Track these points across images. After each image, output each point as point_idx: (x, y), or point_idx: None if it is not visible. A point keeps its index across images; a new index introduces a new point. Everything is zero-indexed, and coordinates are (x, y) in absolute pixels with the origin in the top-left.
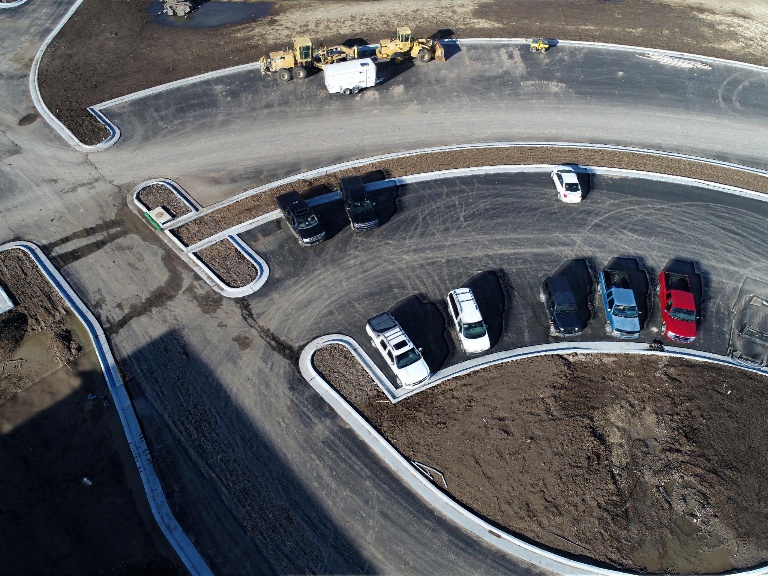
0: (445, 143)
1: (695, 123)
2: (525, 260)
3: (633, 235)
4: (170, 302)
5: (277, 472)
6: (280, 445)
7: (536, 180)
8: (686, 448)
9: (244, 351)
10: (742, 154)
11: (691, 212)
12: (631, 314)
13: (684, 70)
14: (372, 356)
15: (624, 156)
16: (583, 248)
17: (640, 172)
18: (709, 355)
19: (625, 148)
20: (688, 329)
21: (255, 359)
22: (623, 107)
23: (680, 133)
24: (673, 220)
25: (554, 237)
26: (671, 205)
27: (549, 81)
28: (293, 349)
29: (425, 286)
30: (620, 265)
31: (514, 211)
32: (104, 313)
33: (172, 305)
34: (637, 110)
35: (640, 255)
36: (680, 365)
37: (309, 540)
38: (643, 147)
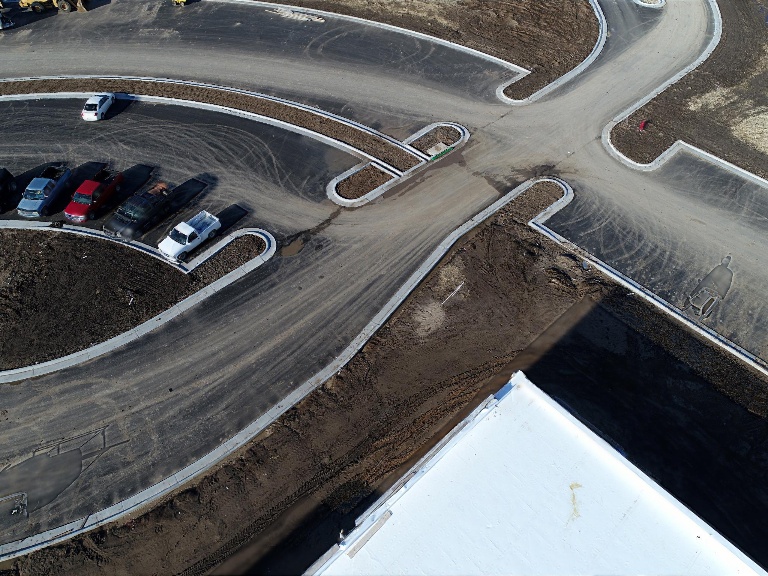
0: (28, 75)
1: (267, 64)
2: (10, 162)
3: (124, 146)
4: None
5: None
6: None
7: (81, 104)
8: (13, 295)
9: None
10: (285, 88)
11: (194, 131)
12: (38, 197)
13: (298, 22)
14: None
15: (176, 88)
16: (69, 154)
17: (179, 100)
18: (96, 232)
19: (184, 82)
20: (79, 209)
21: None
22: (214, 50)
23: (246, 71)
24: (171, 136)
25: (53, 146)
26: (181, 125)
27: (166, 29)
28: None
29: None
30: (89, 167)
31: (38, 127)
32: None
33: None
34: (224, 53)
35: (114, 161)
36: (63, 238)
37: None
38: (202, 81)
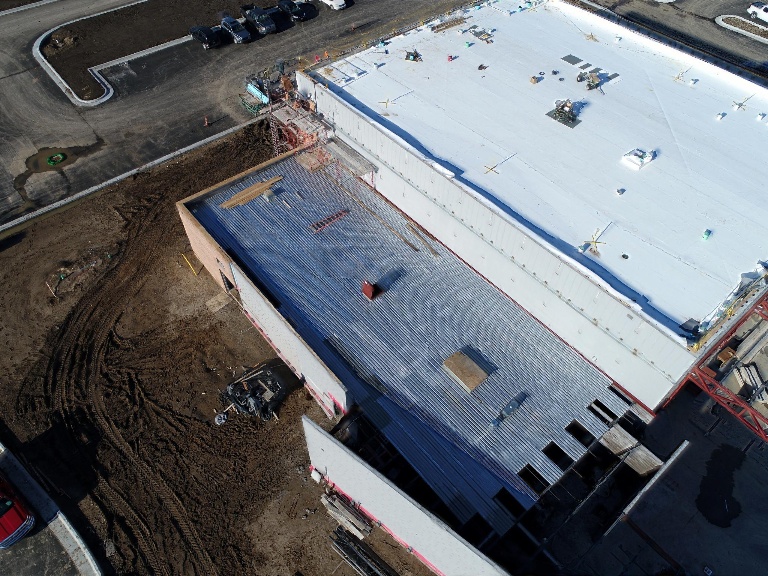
0: None
1: None
2: None
3: None
4: (632, 2)
5: (730, 49)
6: (726, 43)
7: None
8: None
9: (684, 18)
10: None
11: None
12: None
13: None
14: (753, 21)
15: None
16: None
17: None
18: None
19: None
20: None
21: (692, 20)
22: None
23: None
24: None
25: None
26: None
27: None
28: (709, 18)
29: (767, 2)
30: None
31: None
32: (601, 4)
33: (634, 3)
34: None
35: None
36: None
37: (760, 65)
38: None
